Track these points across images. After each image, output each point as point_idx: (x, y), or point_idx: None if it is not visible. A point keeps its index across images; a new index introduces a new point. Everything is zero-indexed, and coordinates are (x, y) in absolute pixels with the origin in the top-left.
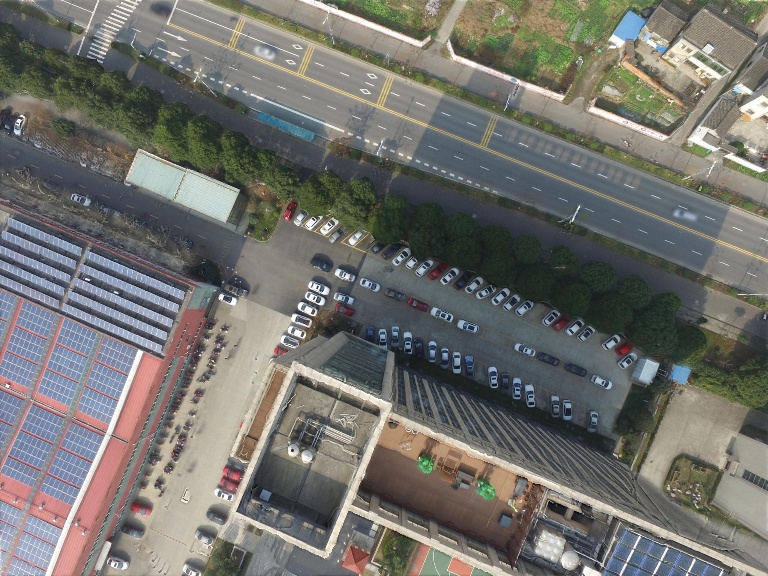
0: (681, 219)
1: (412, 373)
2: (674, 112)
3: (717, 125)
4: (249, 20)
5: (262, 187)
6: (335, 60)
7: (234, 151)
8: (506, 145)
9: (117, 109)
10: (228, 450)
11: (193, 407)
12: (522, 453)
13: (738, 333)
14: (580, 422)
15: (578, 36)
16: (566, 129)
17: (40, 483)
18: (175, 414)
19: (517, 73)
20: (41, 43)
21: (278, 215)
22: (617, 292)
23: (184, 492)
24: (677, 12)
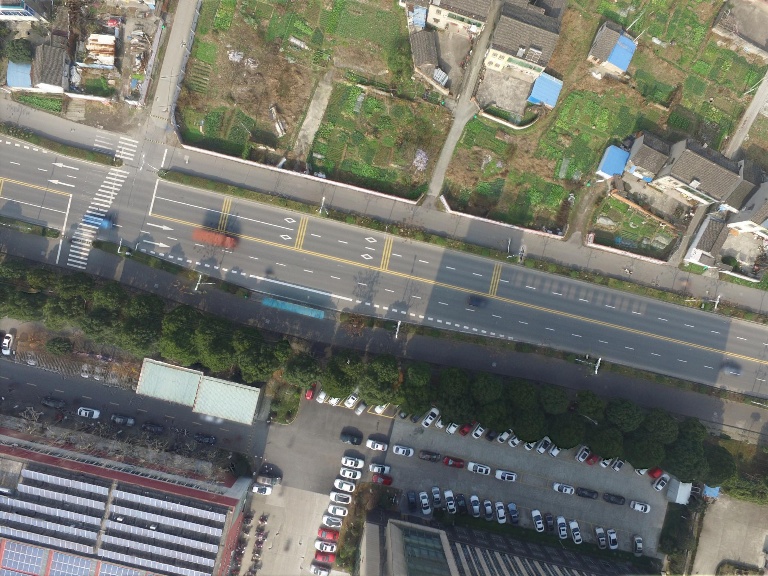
0: (689, 337)
1: (464, 543)
2: (667, 234)
3: (711, 248)
4: (235, 199)
5: None
6: (331, 229)
7: (250, 357)
8: (514, 290)
9: (118, 330)
10: None
11: None
12: None
13: (757, 437)
14: (626, 547)
15: (566, 173)
16: (569, 266)
17: None
18: None
19: (513, 217)
20: (15, 253)
21: (299, 396)
22: (646, 429)
23: None
24: (659, 146)
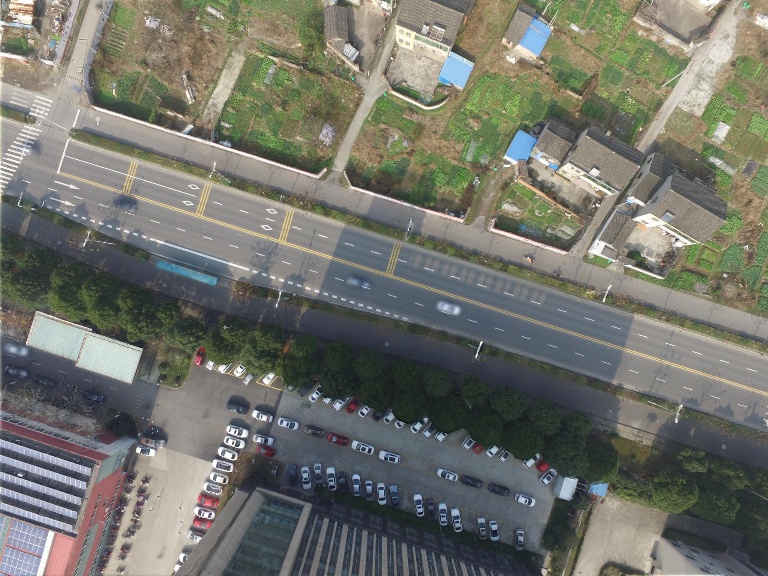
0: (588, 331)
1: (333, 519)
2: (573, 225)
3: (613, 240)
4: (142, 163)
5: None
6: (233, 198)
7: (130, 316)
8: (412, 271)
9: (6, 280)
10: None
11: (121, 563)
12: None
13: (652, 439)
14: (508, 540)
15: (473, 156)
16: (469, 250)
17: None
18: (103, 572)
19: (416, 197)
20: None
21: (189, 361)
22: (528, 419)
23: None
24: (564, 132)
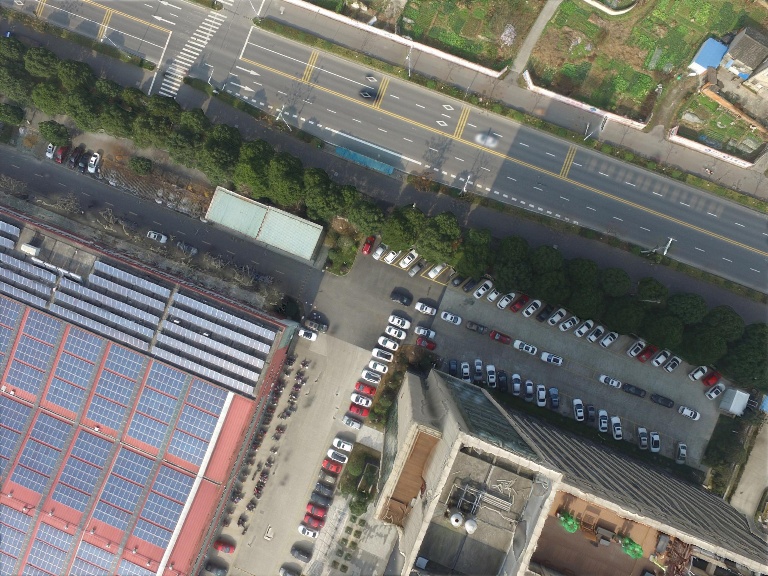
0: (766, 247)
1: None
2: (756, 139)
3: None
4: (322, 53)
5: (339, 221)
6: (410, 92)
7: (320, 189)
8: (586, 175)
9: (199, 148)
10: (311, 486)
11: (274, 443)
12: (656, 505)
13: None
14: (668, 454)
15: (656, 63)
16: (647, 158)
17: (132, 527)
18: (256, 451)
19: (595, 102)
20: (113, 80)
21: (356, 249)
22: (708, 324)
23: (267, 529)
24: (761, 39)
